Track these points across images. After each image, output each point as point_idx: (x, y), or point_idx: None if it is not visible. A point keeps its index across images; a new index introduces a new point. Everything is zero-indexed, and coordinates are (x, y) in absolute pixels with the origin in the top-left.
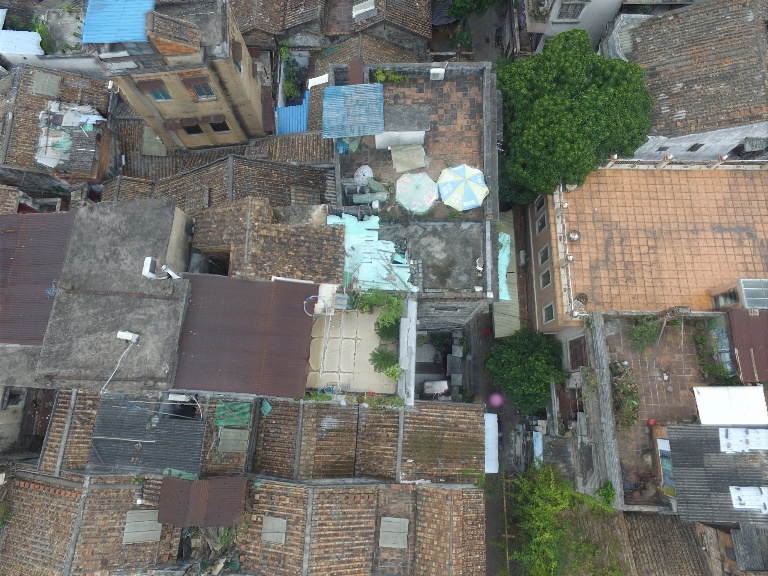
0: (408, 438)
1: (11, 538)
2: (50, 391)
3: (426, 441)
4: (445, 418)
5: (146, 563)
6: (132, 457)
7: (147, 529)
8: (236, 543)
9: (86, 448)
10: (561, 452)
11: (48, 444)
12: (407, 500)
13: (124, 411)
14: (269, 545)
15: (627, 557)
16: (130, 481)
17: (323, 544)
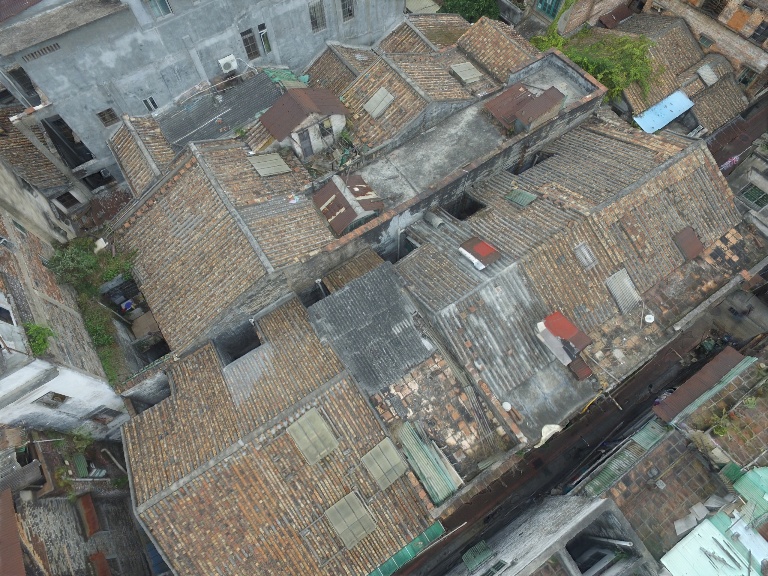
0: (425, 33)
1: (149, 261)
2: (94, 203)
3: (439, 34)
4: (440, 21)
5: (293, 187)
6: (219, 129)
7: (274, 165)
8: (356, 147)
9: (170, 154)
10: (532, 26)
11: (130, 175)
12: (458, 57)
13: (185, 113)
14: (383, 117)
15: (623, 35)
16: (231, 143)
17: (423, 82)
